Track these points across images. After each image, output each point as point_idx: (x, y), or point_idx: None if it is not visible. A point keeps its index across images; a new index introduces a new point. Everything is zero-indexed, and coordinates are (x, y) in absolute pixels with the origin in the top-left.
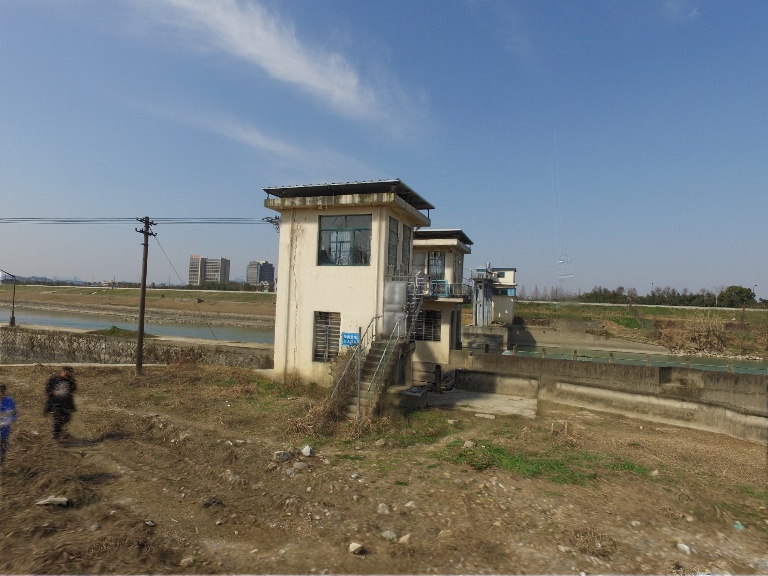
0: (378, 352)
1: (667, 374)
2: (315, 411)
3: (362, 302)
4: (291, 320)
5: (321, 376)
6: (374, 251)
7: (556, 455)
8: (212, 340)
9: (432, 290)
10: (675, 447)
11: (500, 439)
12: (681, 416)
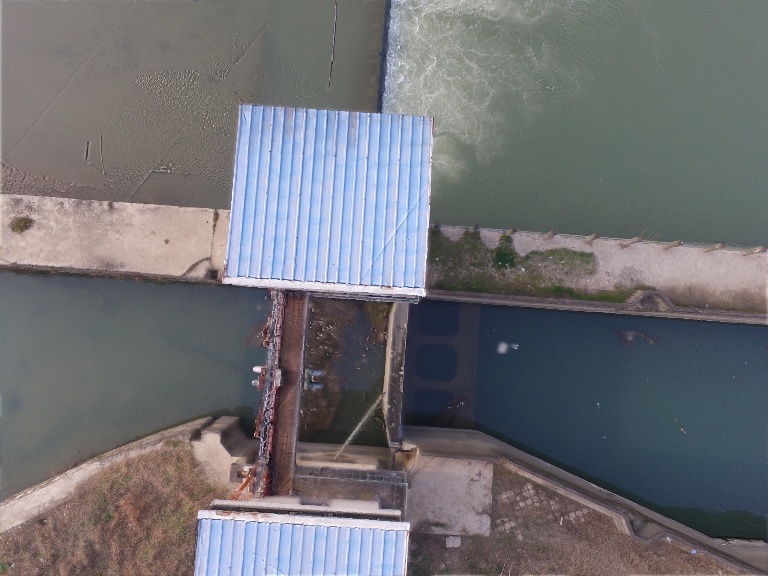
0: None
1: None
2: None
3: None
4: None
5: None
6: None
7: None
8: None
9: None
10: (570, 573)
11: None
12: None
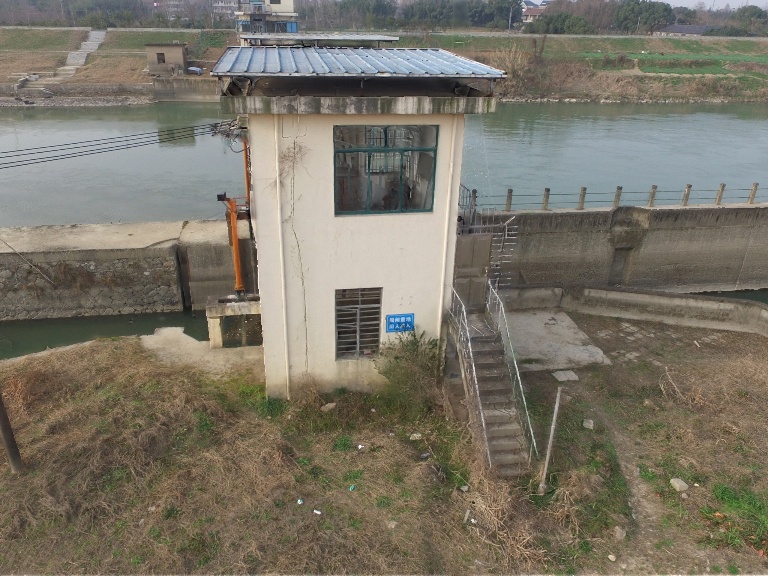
0: (479, 353)
1: (616, 217)
2: (502, 506)
3: (421, 269)
4: (293, 308)
5: (353, 377)
6: (443, 190)
7: (763, 473)
8: None
9: None
10: (763, 381)
11: (690, 459)
12: (717, 317)
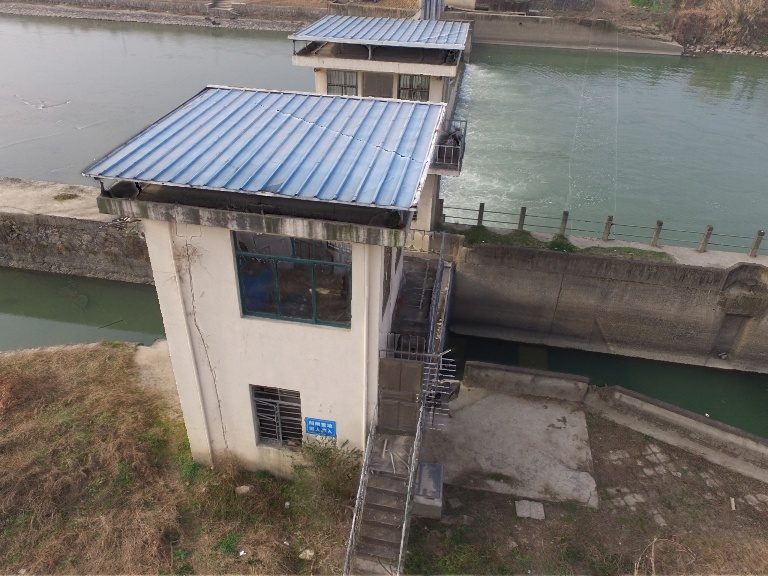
0: (382, 492)
1: (735, 275)
2: None
3: (339, 383)
4: (207, 392)
5: (276, 464)
6: (359, 311)
7: None
8: (21, 190)
9: (435, 252)
10: None
11: None
12: None
